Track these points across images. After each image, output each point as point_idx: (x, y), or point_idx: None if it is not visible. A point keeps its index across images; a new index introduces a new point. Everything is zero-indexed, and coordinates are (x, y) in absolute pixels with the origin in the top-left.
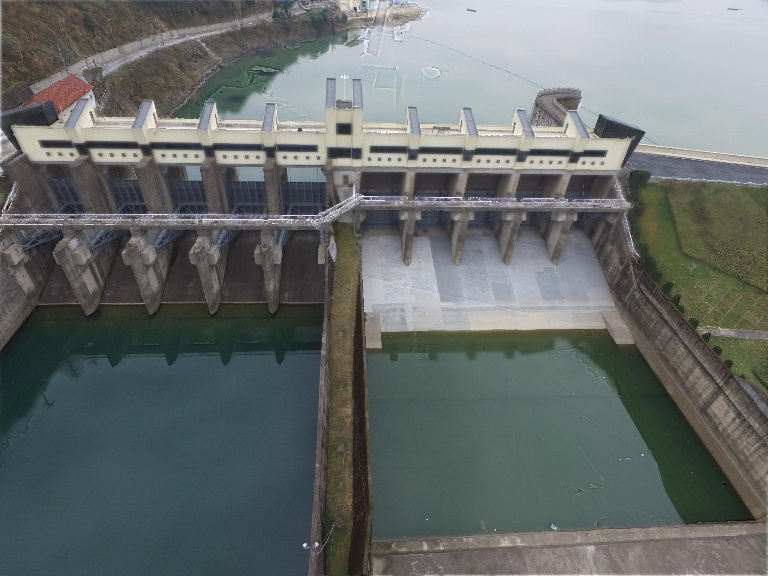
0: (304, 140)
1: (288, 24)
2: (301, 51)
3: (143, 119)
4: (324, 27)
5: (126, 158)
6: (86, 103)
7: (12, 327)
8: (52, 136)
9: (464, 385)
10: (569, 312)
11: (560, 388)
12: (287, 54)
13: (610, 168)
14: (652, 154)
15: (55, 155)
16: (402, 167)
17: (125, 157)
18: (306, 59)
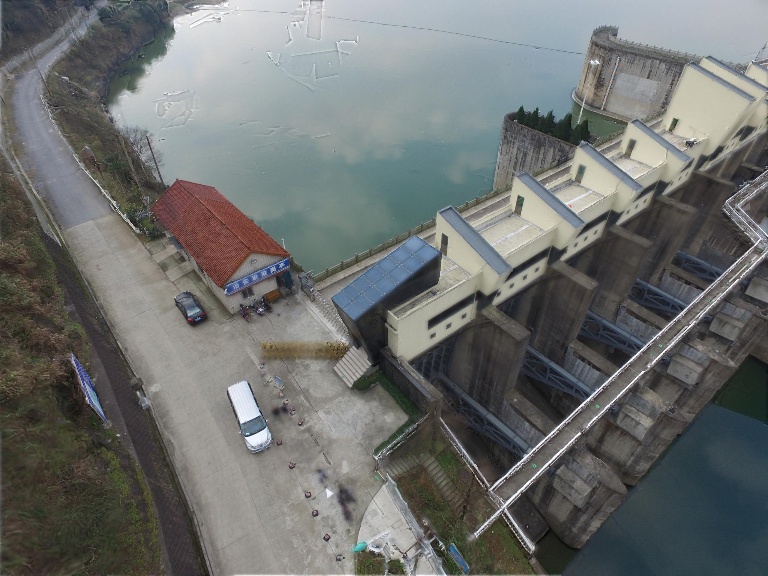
0: None
1: (125, 25)
2: (146, 58)
3: (560, 206)
4: (157, 20)
5: (525, 281)
6: None
7: None
8: (451, 301)
9: None
10: None
11: None
12: (136, 66)
13: None
14: None
15: (441, 332)
16: (728, 152)
17: (524, 280)
18: None
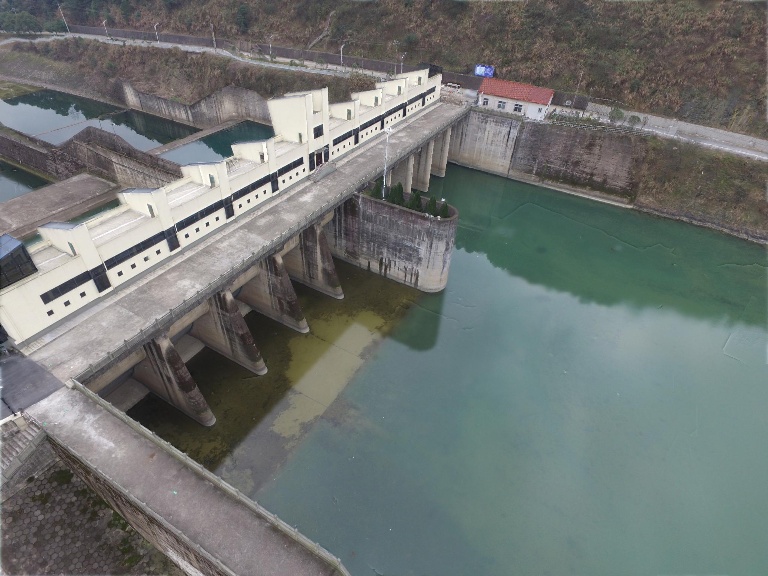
0: None
1: None
2: None
3: None
4: None
5: None
6: (421, 70)
7: None
8: None
9: None
10: None
11: None
12: None
13: None
14: None
15: None
16: None
17: None
18: None
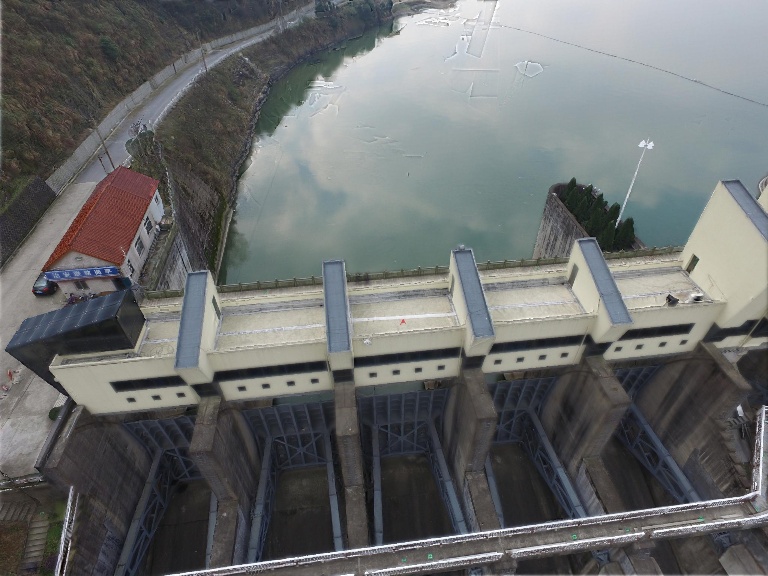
0: (673, 318)
1: (334, 19)
2: (348, 51)
3: (342, 318)
4: (371, 18)
5: (295, 387)
6: (206, 286)
7: None
8: (141, 372)
9: None
10: None
11: None
12: (334, 57)
13: None
14: None
15: (146, 400)
16: None
17: (293, 386)
18: (351, 59)
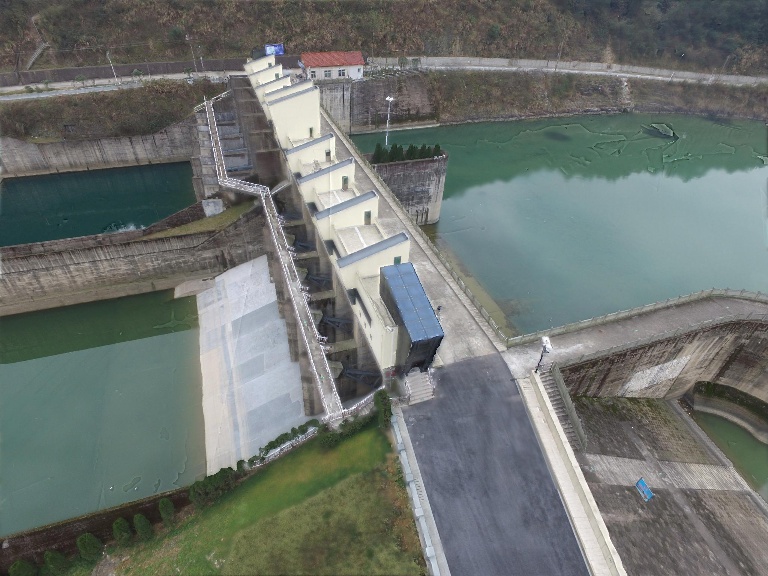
0: None
1: None
2: None
3: None
4: None
5: None
6: (269, 56)
7: (184, 157)
8: None
9: (124, 358)
10: (231, 448)
11: (135, 462)
12: None
13: (377, 356)
14: (549, 463)
15: None
16: None
17: None
18: None
